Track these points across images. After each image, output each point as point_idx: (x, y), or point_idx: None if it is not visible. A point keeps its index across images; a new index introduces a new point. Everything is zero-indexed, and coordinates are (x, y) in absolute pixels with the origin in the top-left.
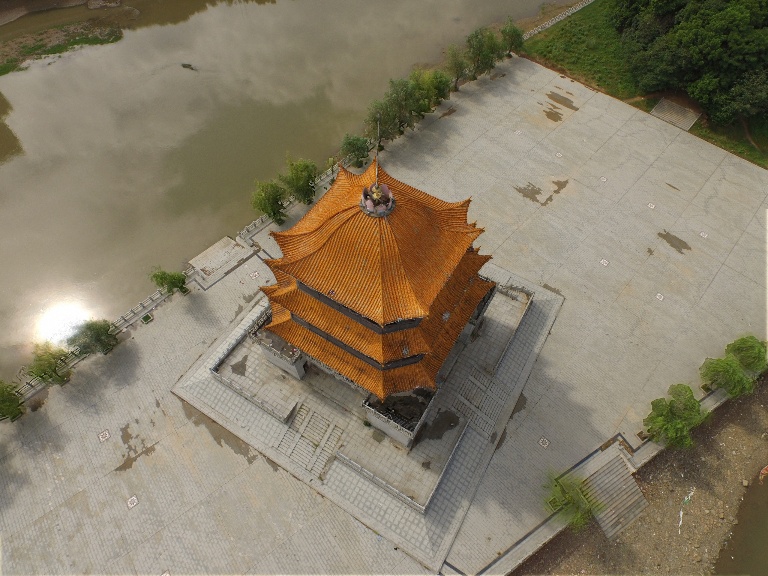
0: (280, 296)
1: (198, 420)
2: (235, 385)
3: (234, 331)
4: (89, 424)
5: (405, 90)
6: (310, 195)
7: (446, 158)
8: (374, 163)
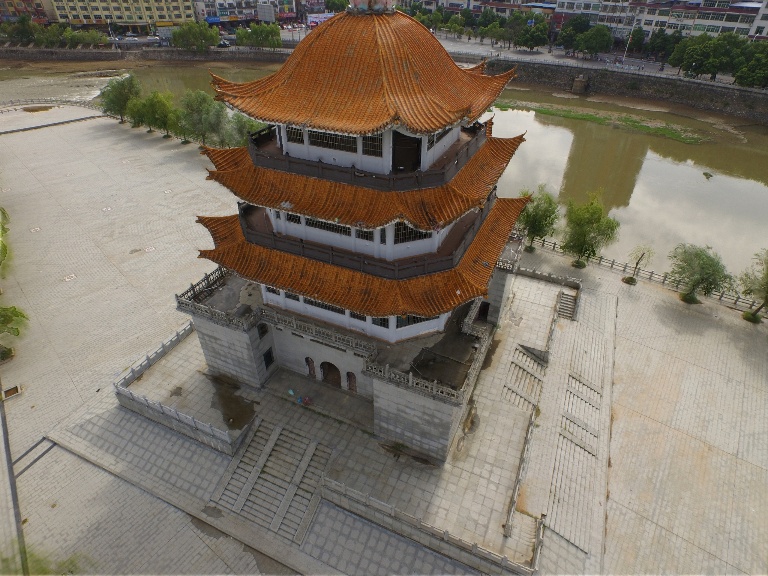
0: None
1: None
2: None
3: None
4: None
5: None
6: (579, 252)
7: None
8: None
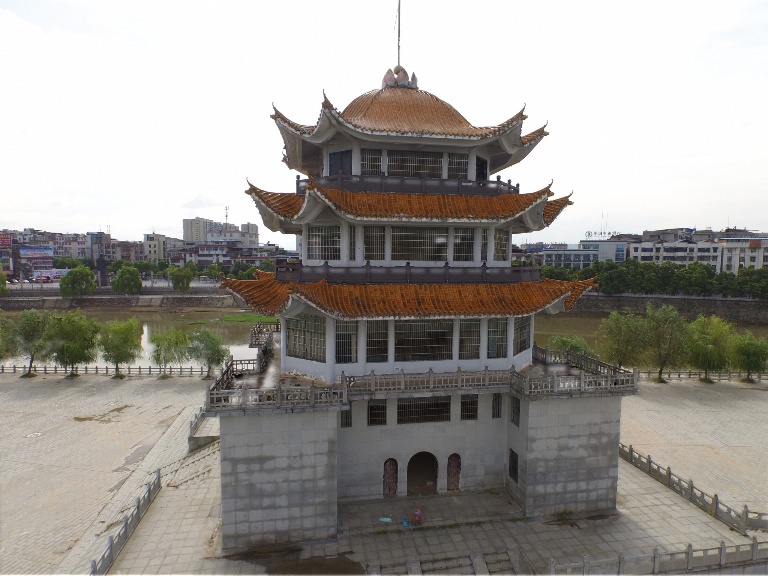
0: None
1: (160, 427)
2: None
3: None
4: (124, 395)
5: (671, 321)
6: None
7: (724, 409)
8: None
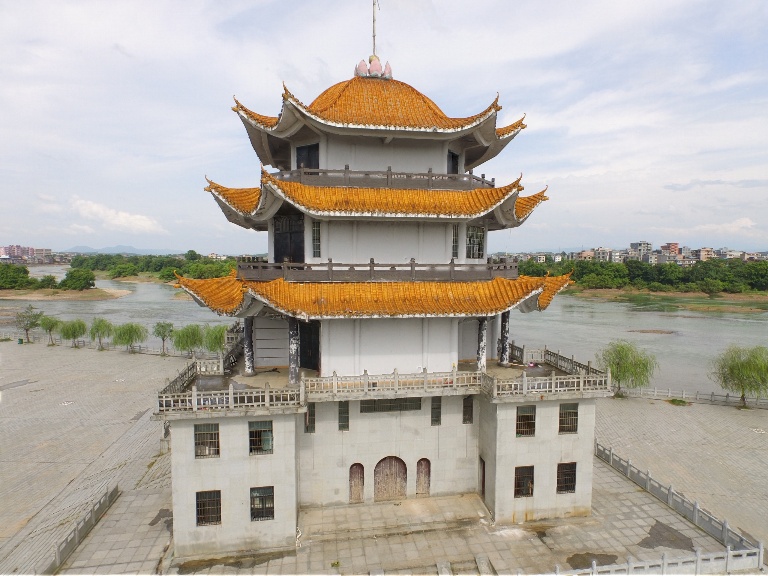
0: (527, 198)
1: None
2: (684, 503)
3: None
4: None
5: None
6: None
7: None
8: (246, 110)
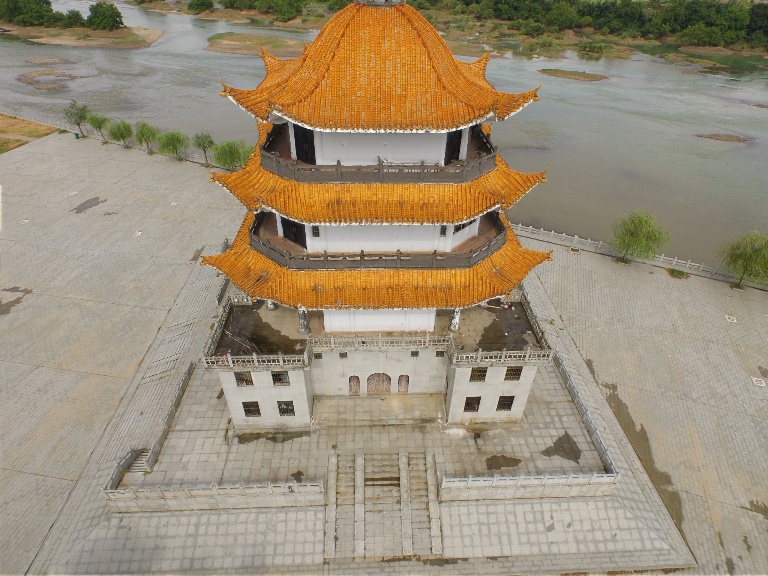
0: (526, 175)
1: (663, 480)
2: (591, 424)
3: (523, 550)
4: None
5: None
6: None
7: None
8: (235, 92)
